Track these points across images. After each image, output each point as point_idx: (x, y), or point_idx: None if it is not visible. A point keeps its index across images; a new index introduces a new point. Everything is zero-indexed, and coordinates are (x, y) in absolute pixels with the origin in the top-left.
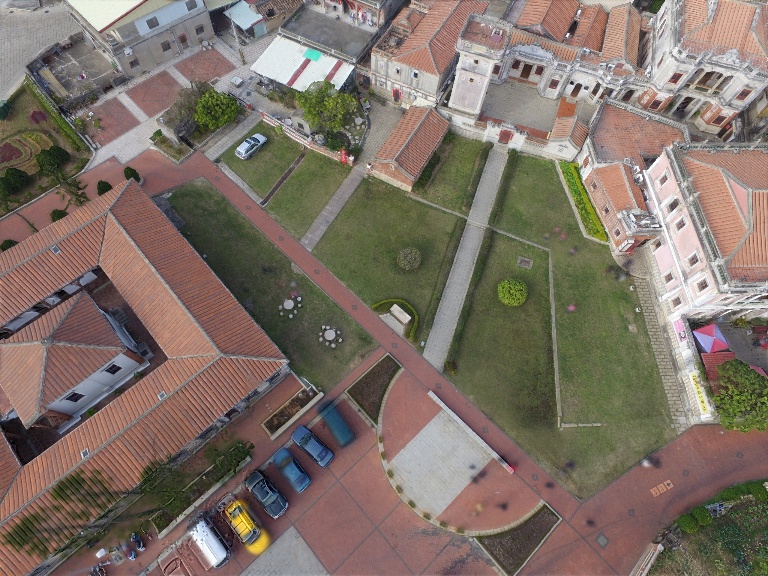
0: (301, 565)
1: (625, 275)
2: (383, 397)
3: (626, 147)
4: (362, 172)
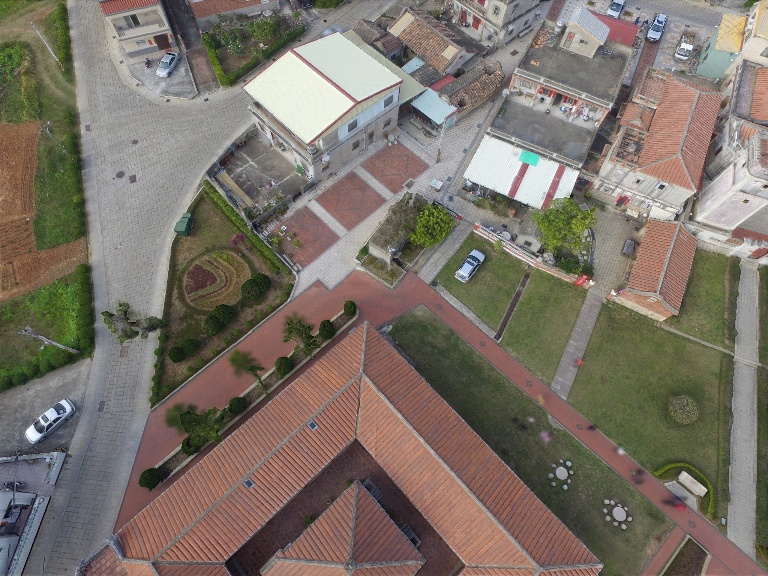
0: None
1: None
2: None
3: None
4: (599, 296)
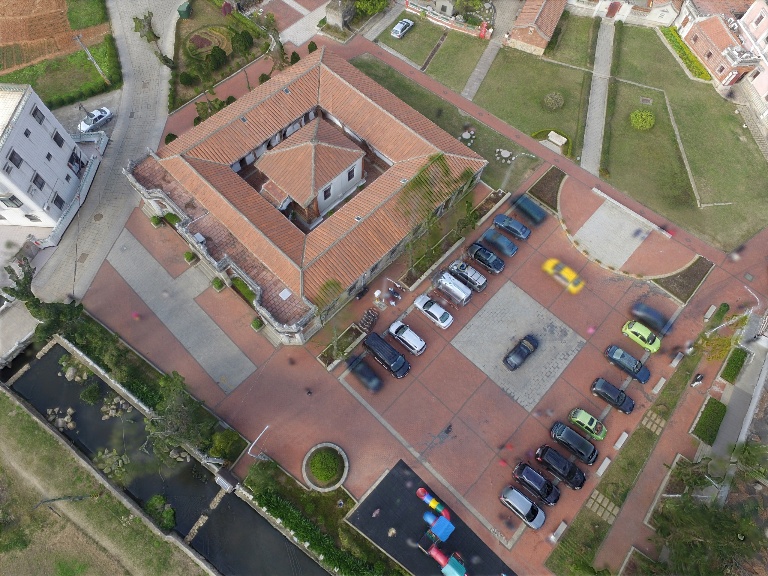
0: (523, 304)
1: (729, 104)
2: (557, 194)
3: (718, 7)
4: (498, 44)
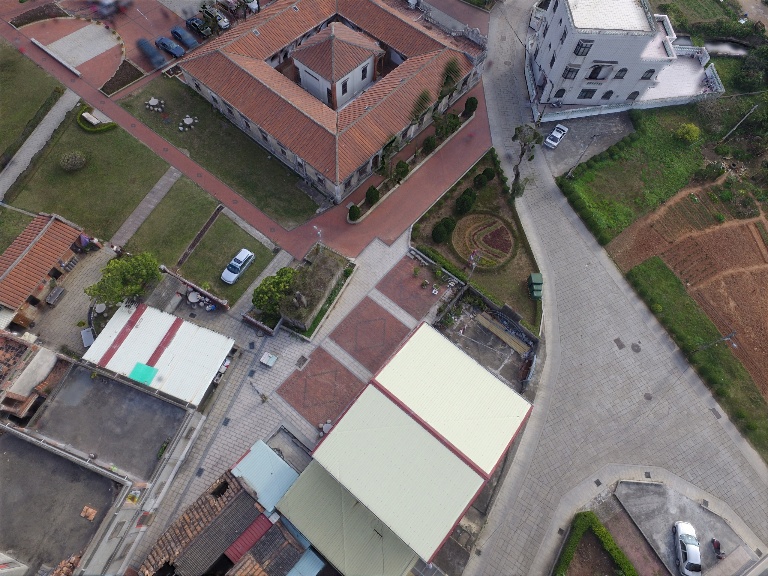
0: (180, 7)
1: None
2: None
3: None
4: (109, 248)
